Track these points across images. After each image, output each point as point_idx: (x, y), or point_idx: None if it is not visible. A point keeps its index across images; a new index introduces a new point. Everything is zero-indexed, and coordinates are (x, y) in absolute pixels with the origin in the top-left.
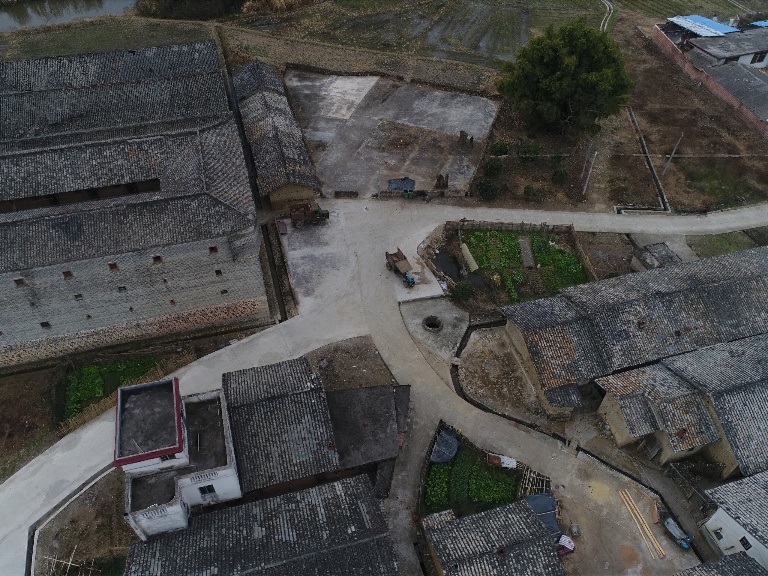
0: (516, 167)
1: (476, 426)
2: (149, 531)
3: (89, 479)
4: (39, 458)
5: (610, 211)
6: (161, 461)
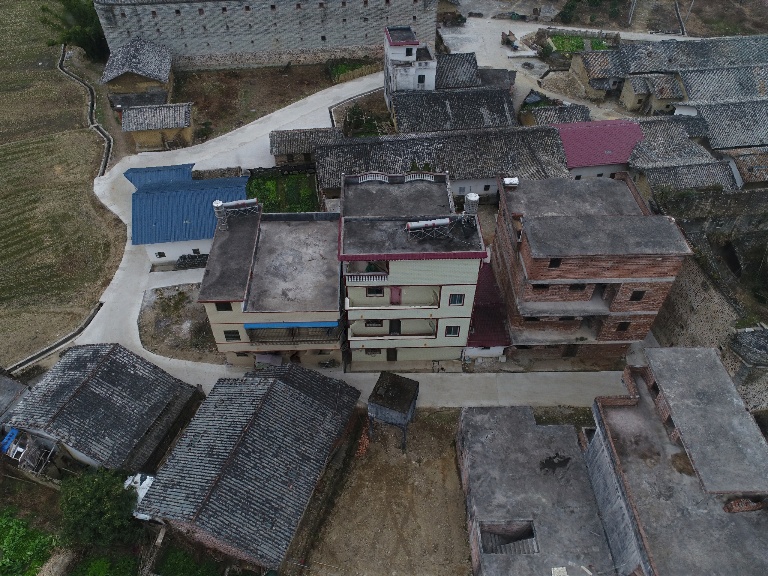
0: (586, 11)
1: (550, 97)
2: (398, 86)
3: (352, 97)
4: (326, 90)
5: (645, 32)
6: (406, 55)
